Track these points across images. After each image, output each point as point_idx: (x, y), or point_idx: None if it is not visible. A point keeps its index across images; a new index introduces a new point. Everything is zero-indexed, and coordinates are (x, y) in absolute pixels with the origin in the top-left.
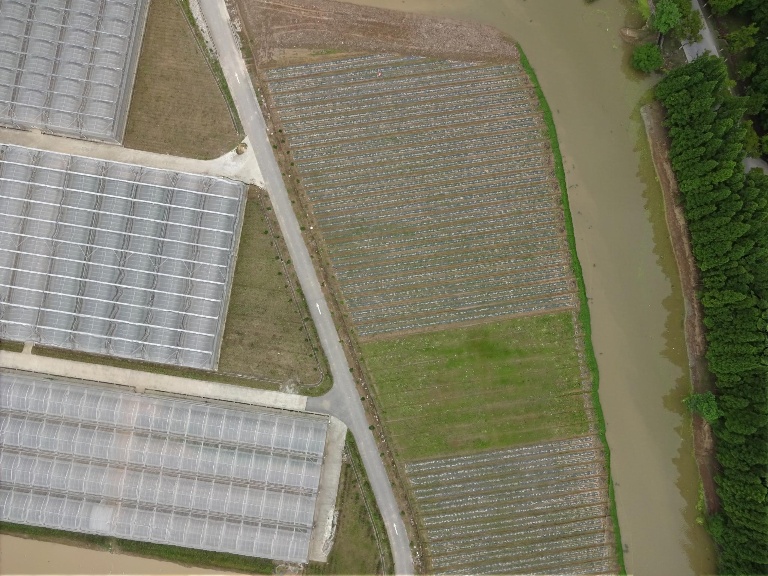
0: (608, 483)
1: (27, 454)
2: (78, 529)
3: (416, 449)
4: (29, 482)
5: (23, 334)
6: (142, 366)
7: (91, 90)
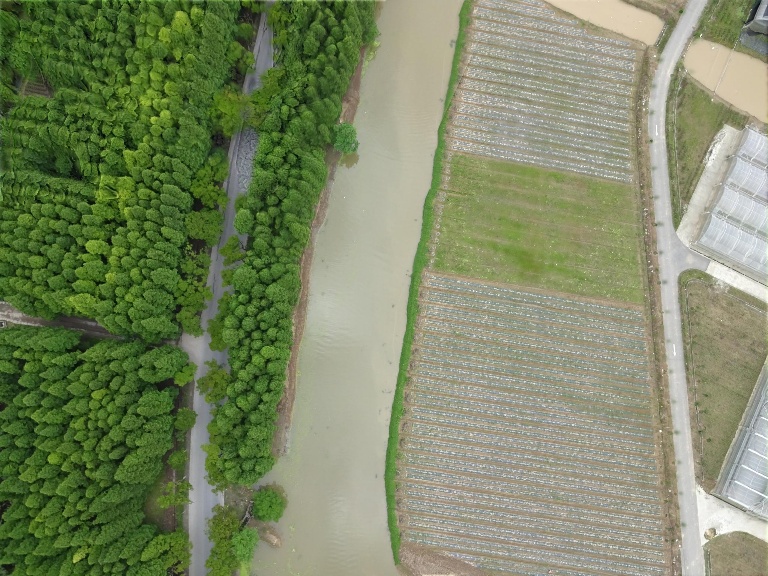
0: (451, 104)
1: None
2: None
3: (618, 193)
4: None
5: None
6: None
7: None
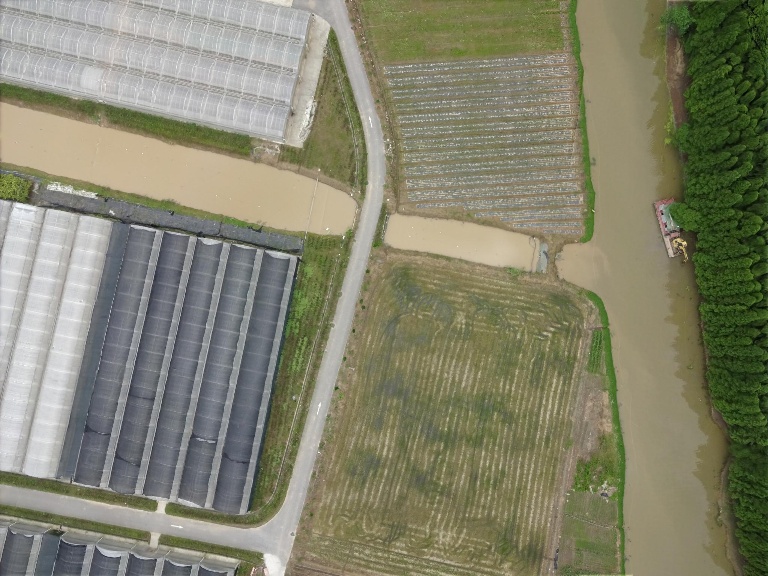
0: (579, 97)
1: (27, 17)
2: (70, 90)
3: (395, 52)
4: (27, 42)
5: None
6: None
7: None
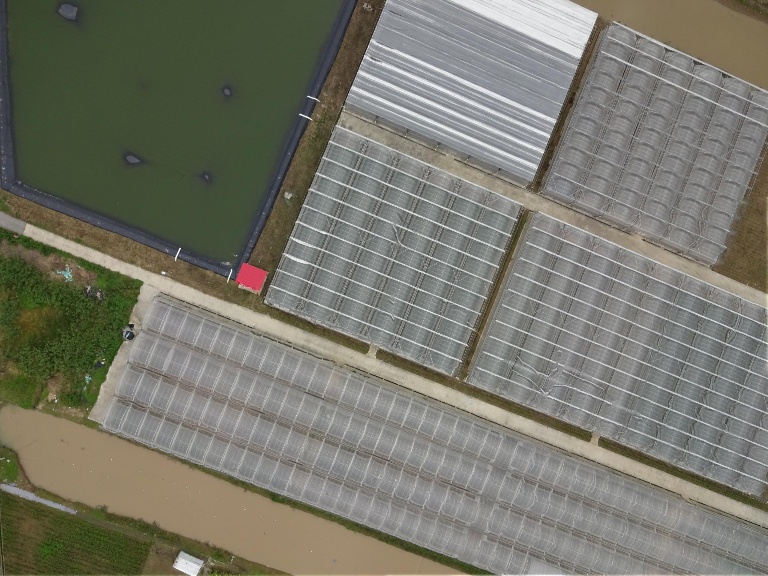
0: None
1: (592, 541)
2: None
3: None
4: None
5: (612, 432)
6: (690, 477)
7: (709, 214)
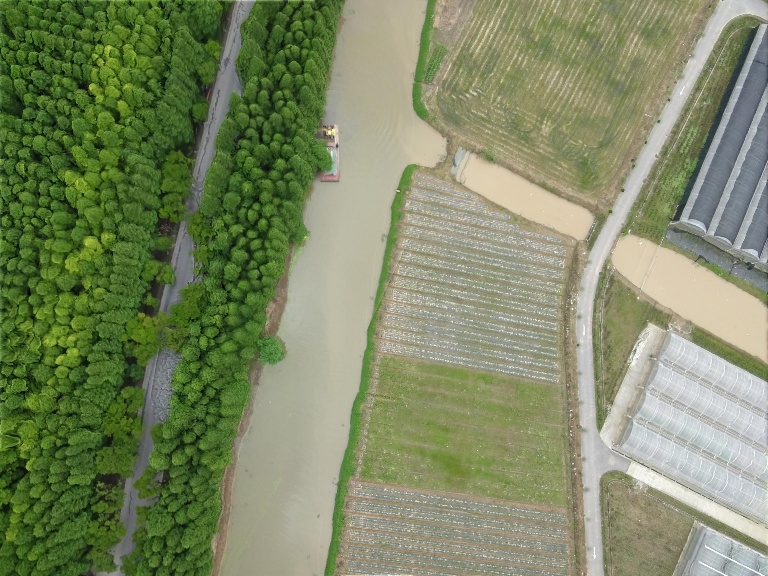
0: (381, 304)
1: None
2: None
3: (545, 394)
4: None
5: None
6: (756, 545)
7: None
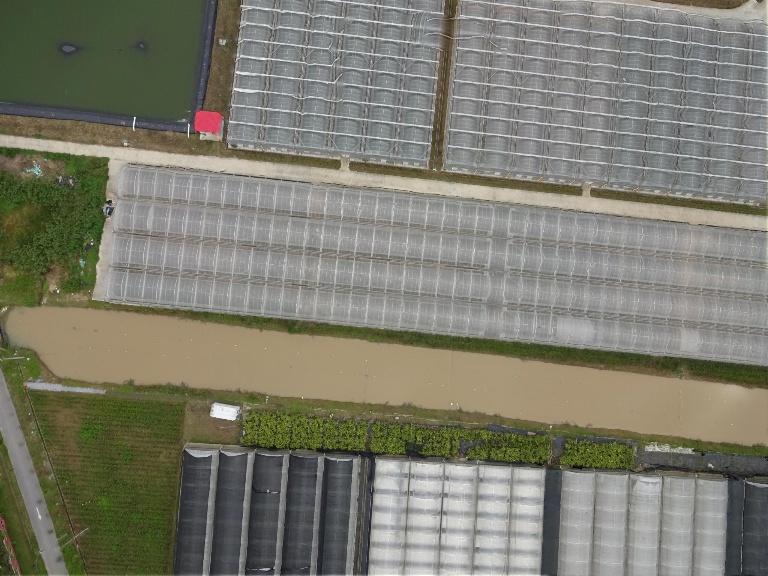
0: None
1: (612, 285)
2: (664, 353)
3: None
4: (618, 311)
5: (599, 173)
6: (693, 203)
7: None
